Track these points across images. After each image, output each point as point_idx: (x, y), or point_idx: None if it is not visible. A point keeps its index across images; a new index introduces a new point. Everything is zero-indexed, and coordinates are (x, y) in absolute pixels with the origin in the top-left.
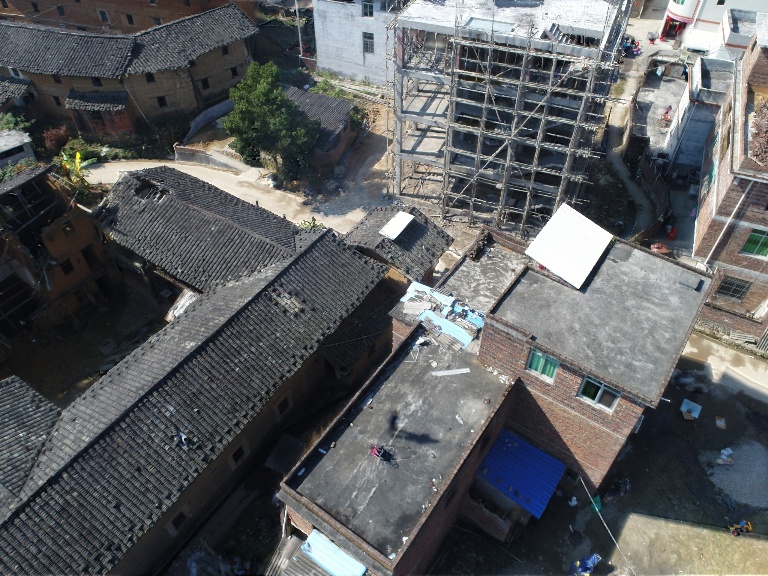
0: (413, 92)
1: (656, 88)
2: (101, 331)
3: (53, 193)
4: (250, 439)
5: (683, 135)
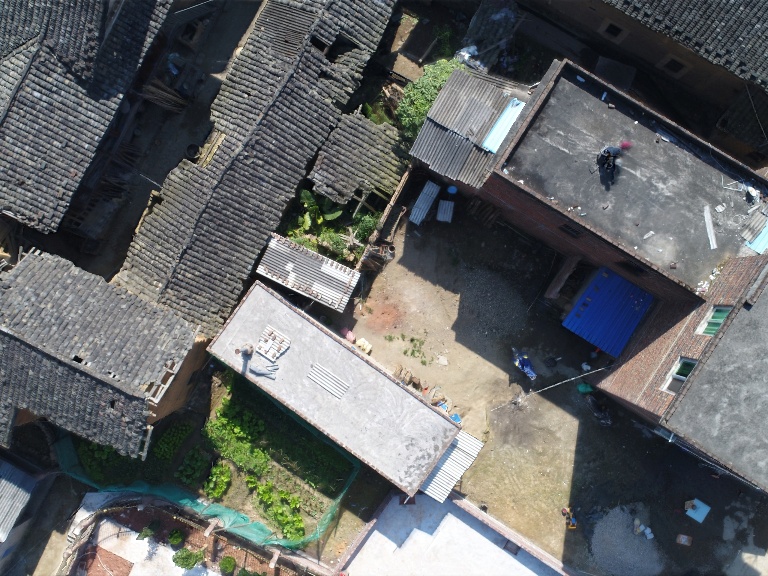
0: None
1: None
2: None
3: None
4: (631, 38)
5: None
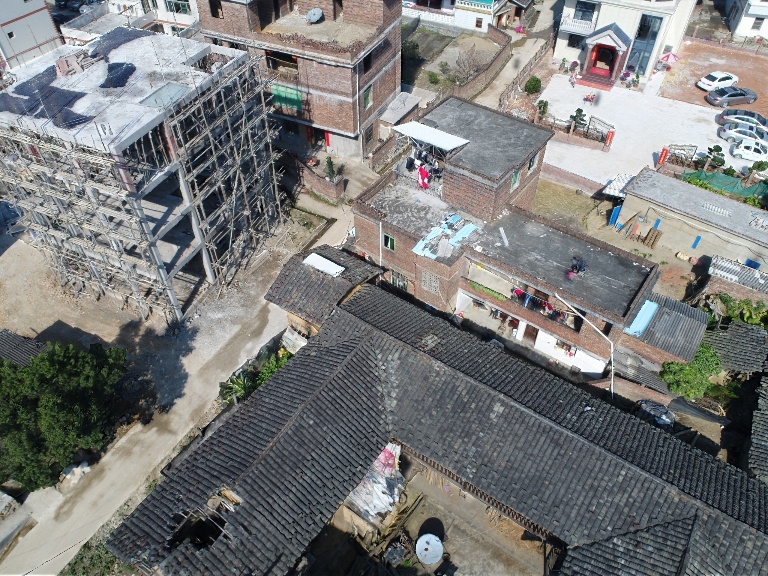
0: (109, 226)
1: None
2: None
3: None
4: None
5: None
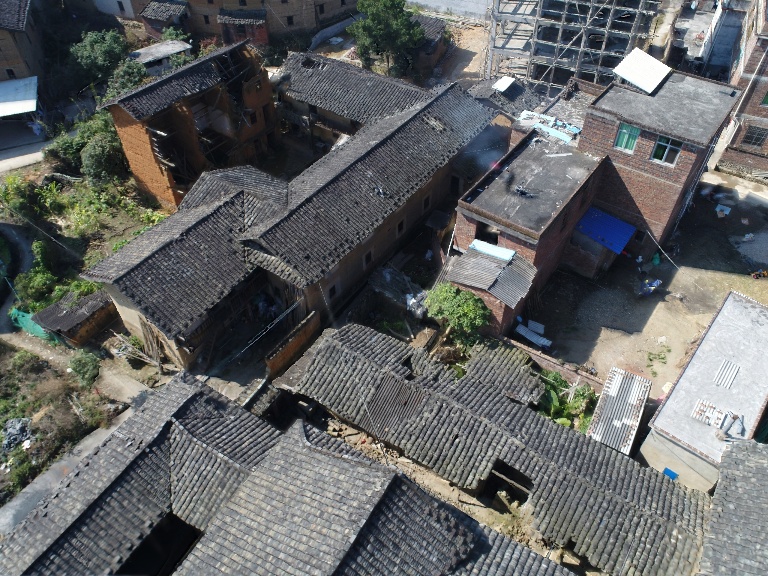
0: (504, 1)
1: (691, 19)
2: (273, 171)
3: (245, 62)
4: (408, 218)
5: (716, 39)
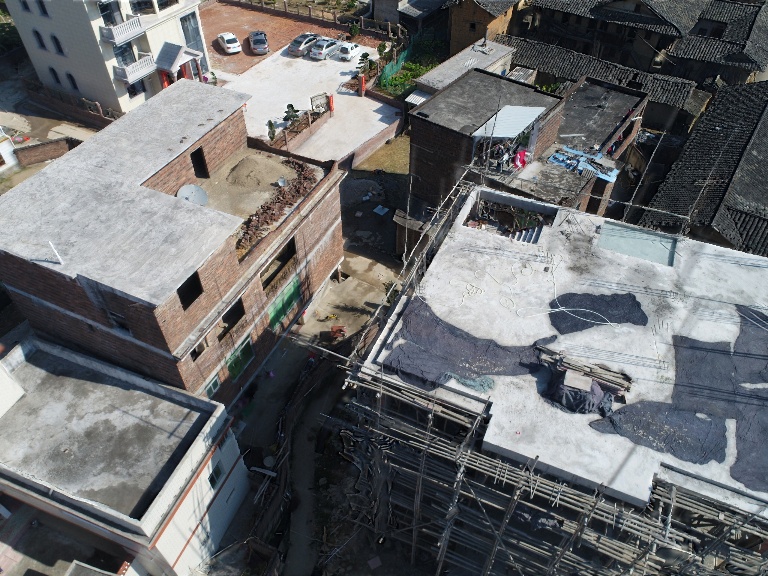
0: None
1: None
2: None
3: None
4: None
5: None
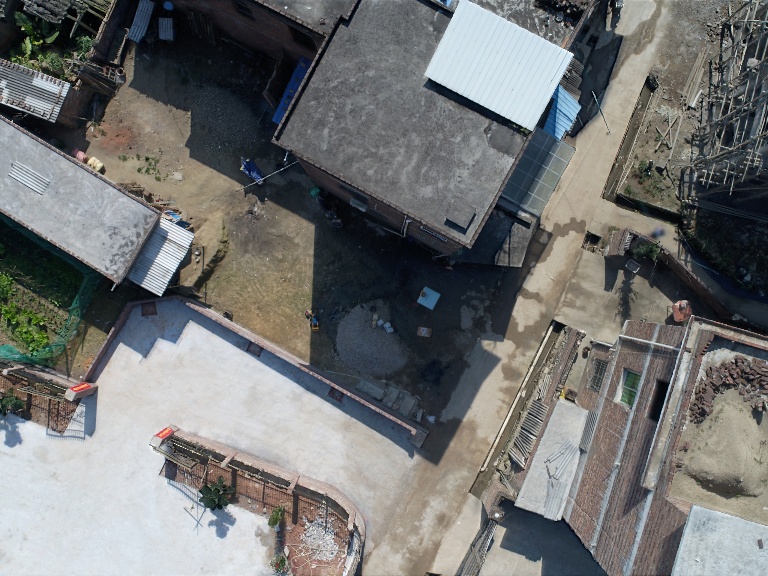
0: None
1: None
2: None
3: None
4: None
5: None
